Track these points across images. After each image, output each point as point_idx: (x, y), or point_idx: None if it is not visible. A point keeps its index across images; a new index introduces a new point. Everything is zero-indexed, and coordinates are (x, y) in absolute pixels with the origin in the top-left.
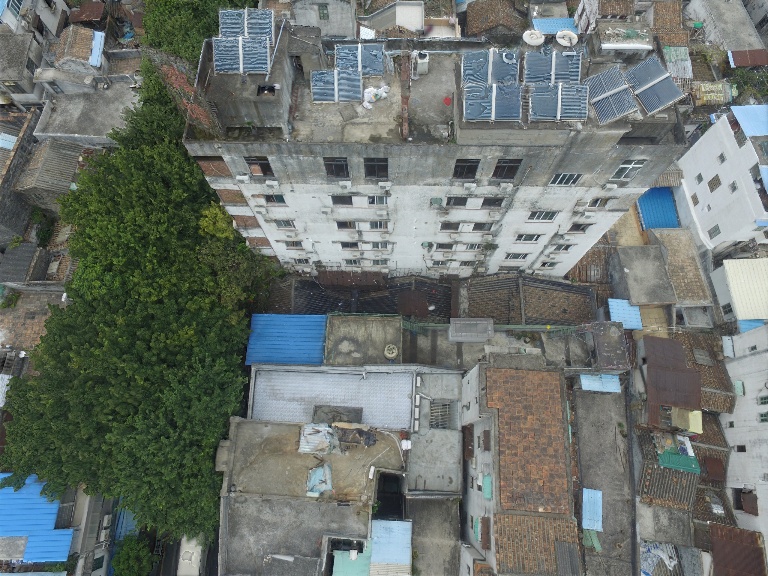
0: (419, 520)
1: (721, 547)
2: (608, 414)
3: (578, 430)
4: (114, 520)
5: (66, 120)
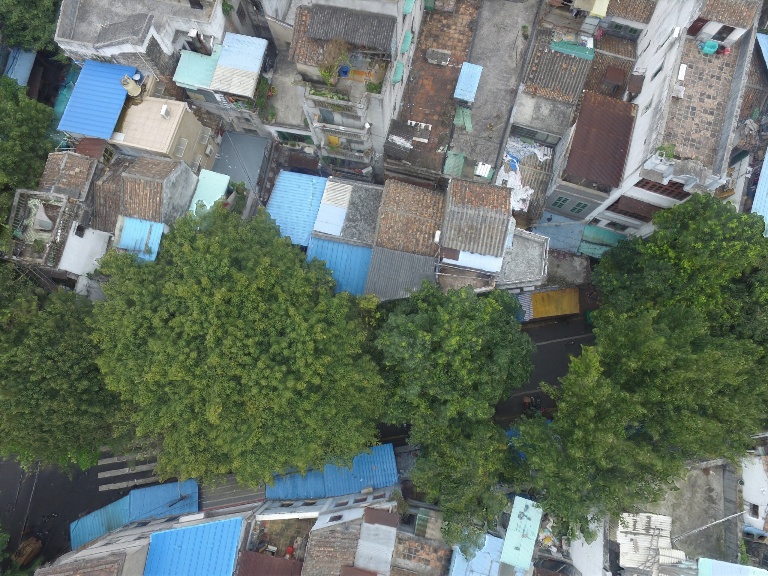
0: (285, 68)
1: (590, 111)
2: (515, 19)
3: (477, 28)
4: (1, 73)
5: None
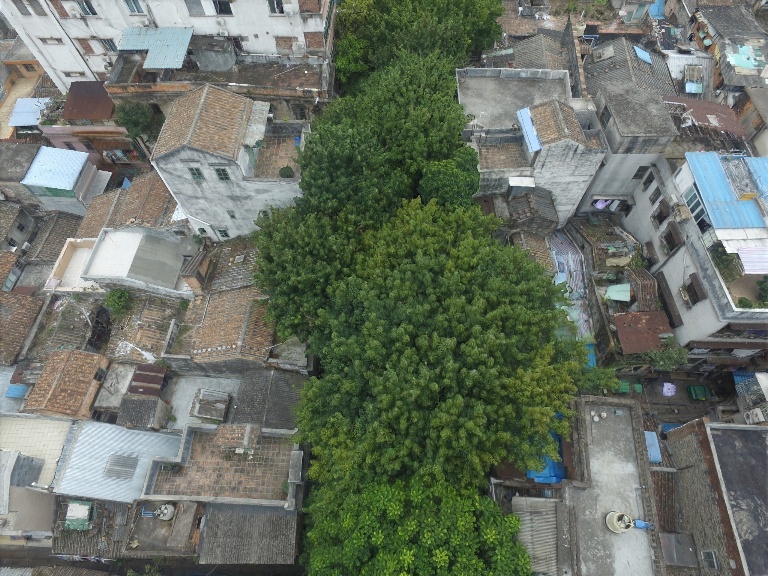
0: None
1: None
2: None
3: None
4: None
5: (547, 97)
